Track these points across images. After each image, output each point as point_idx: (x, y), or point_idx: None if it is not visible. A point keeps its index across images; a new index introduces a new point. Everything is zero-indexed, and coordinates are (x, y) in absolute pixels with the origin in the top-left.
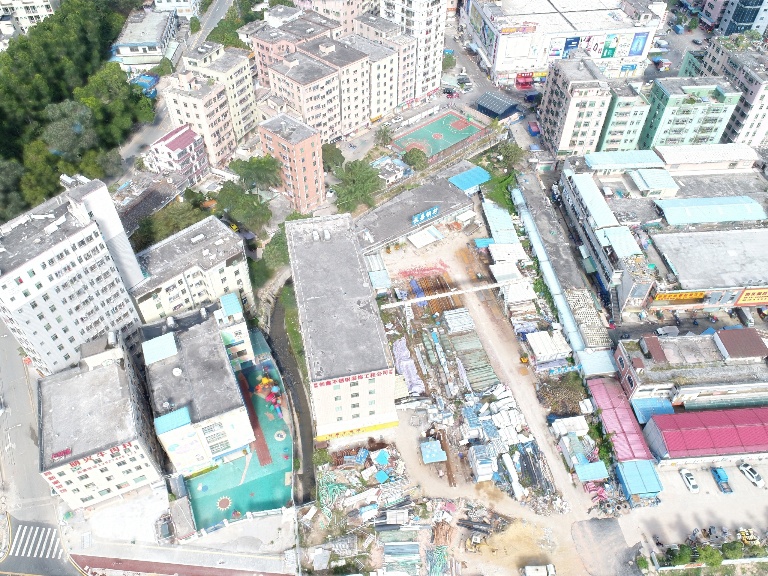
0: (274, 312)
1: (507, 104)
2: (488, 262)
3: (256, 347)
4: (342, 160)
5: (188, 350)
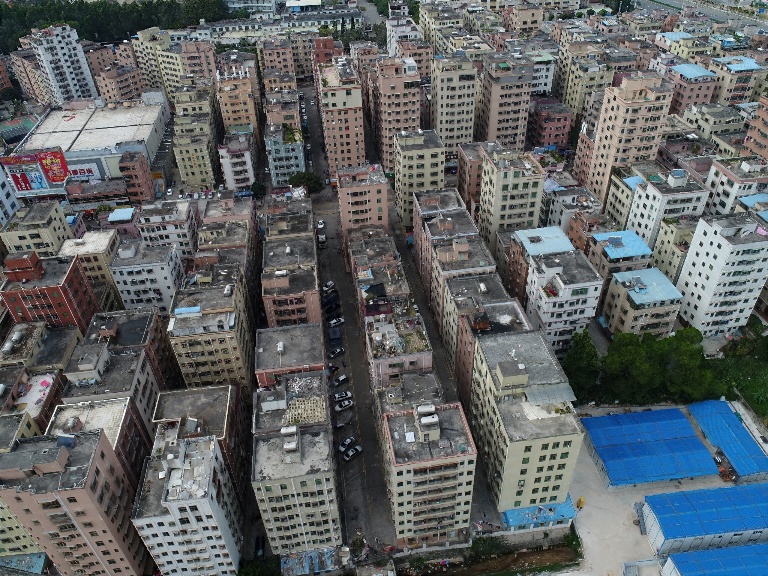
0: None
1: (3, 131)
2: None
3: None
4: (6, 98)
5: None
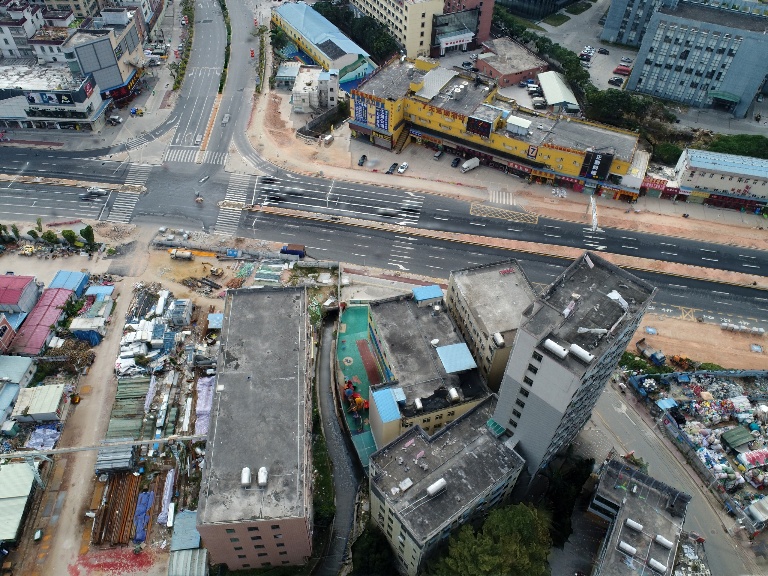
0: (349, 532)
1: None
2: (5, 563)
3: (369, 443)
4: None
5: (430, 368)
